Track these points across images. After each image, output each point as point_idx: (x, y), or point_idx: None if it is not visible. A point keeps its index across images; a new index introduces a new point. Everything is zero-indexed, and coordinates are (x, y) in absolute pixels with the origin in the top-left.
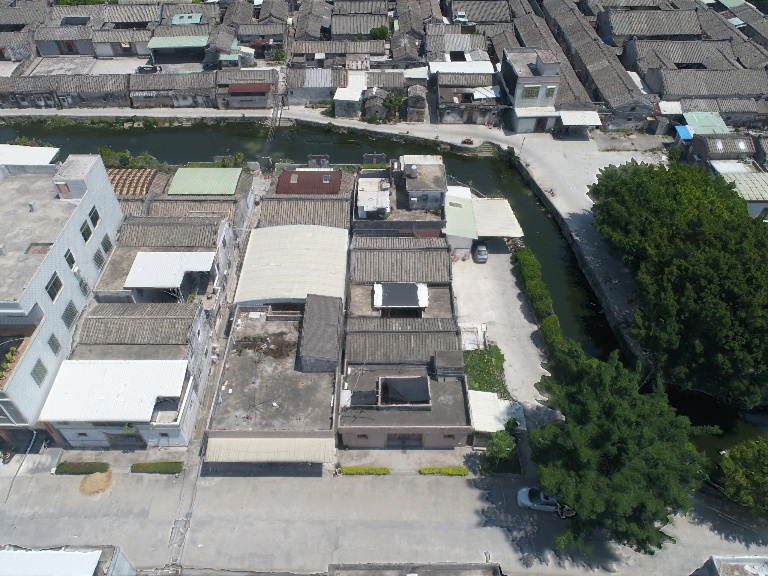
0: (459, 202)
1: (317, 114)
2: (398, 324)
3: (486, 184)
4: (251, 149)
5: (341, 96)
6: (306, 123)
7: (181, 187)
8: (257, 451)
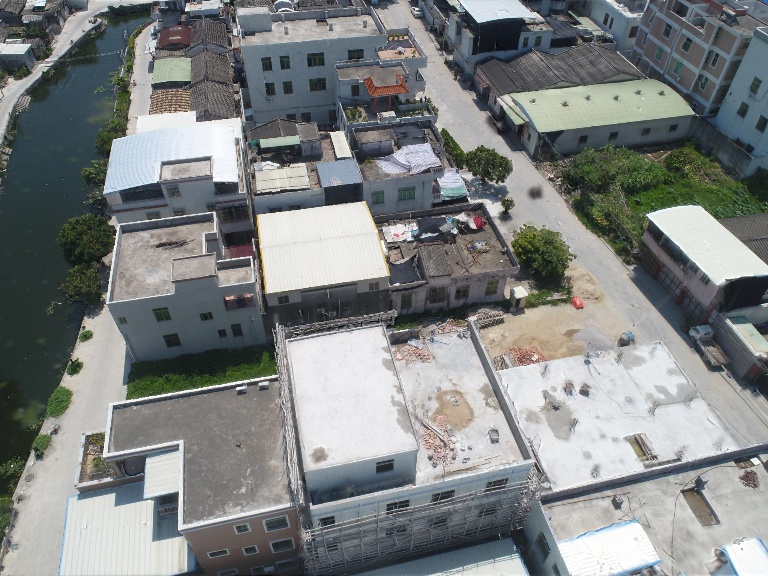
0: None
1: (20, 81)
2: (307, 4)
3: (145, 21)
4: (74, 107)
5: (19, 51)
6: (32, 88)
7: (183, 76)
8: (387, 28)
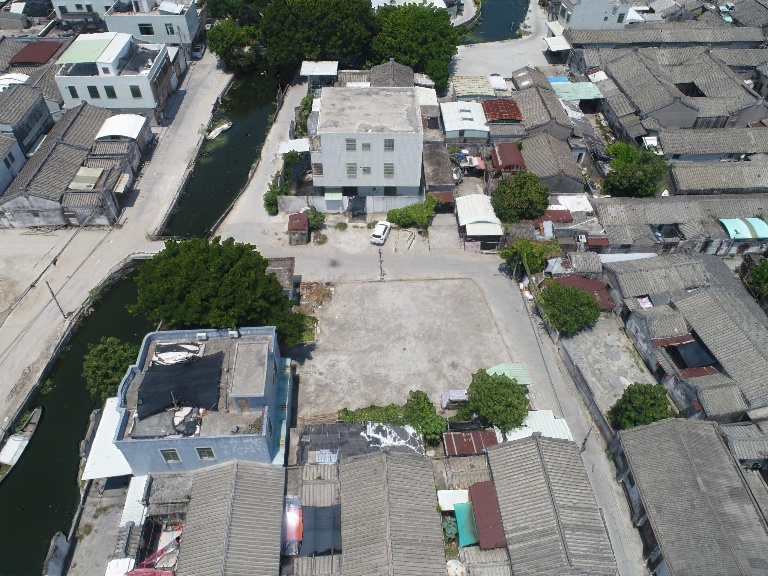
0: (428, 3)
1: None
2: None
3: (482, 36)
4: None
5: None
6: None
7: None
8: None
